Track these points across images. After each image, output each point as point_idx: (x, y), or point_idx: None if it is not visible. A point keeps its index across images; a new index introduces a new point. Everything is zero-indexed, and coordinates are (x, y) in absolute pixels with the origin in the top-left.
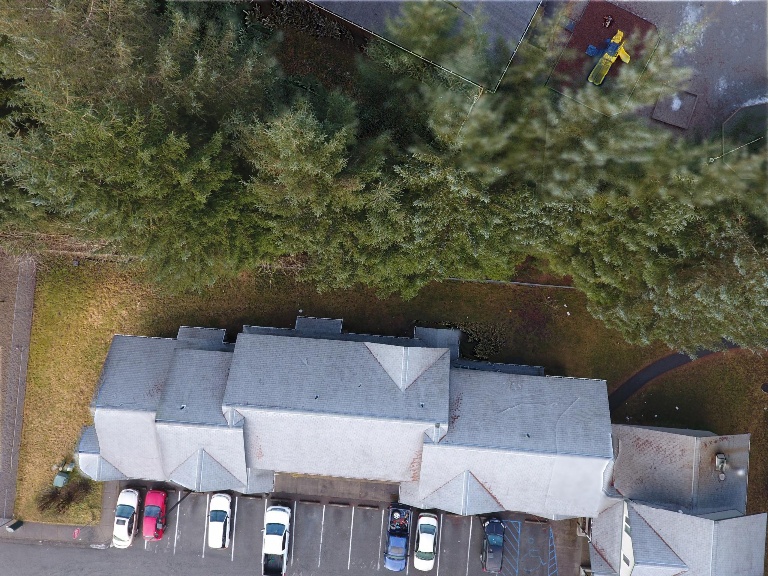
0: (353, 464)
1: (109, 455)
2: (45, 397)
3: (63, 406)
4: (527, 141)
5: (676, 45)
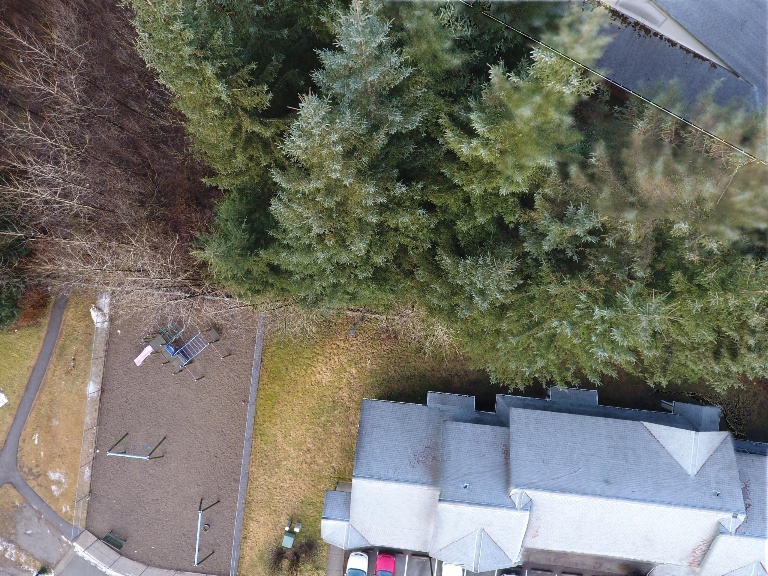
0: (631, 547)
1: (358, 523)
2: (271, 454)
3: (289, 464)
4: None
5: None
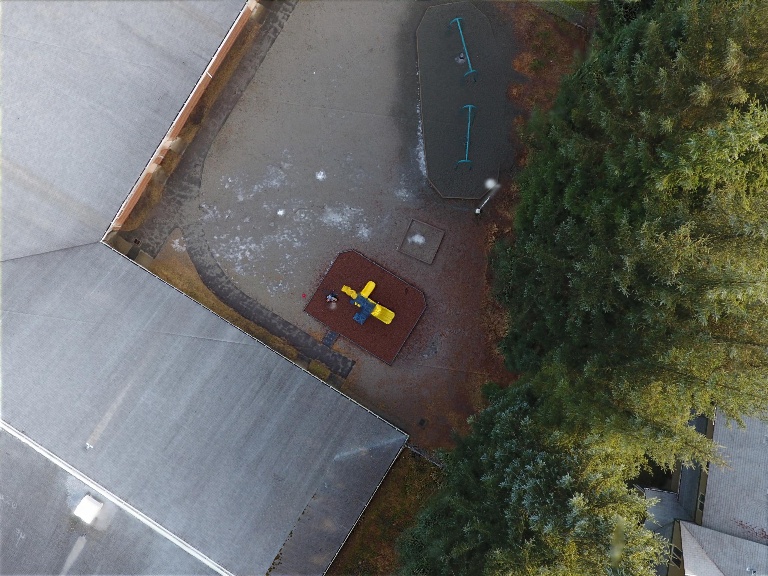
0: None
1: None
2: None
3: None
4: (443, 387)
5: (360, 234)
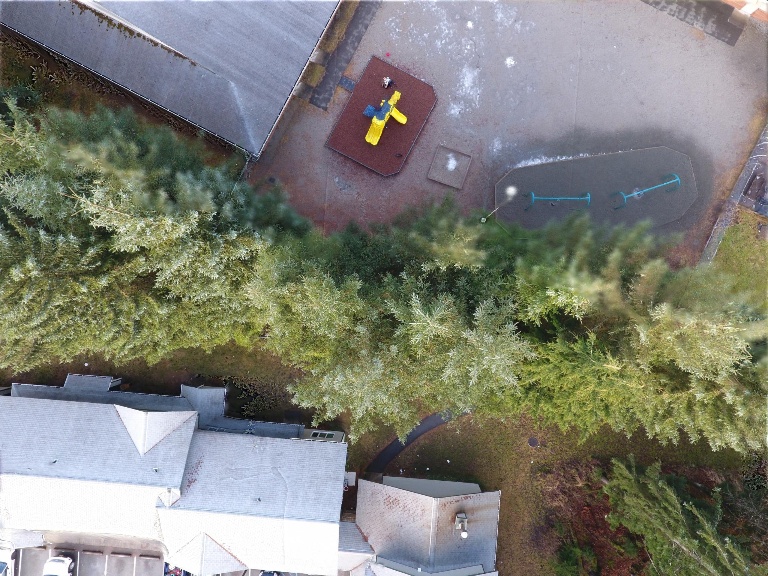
0: (99, 524)
1: None
2: None
3: None
4: (307, 199)
5: (453, 106)
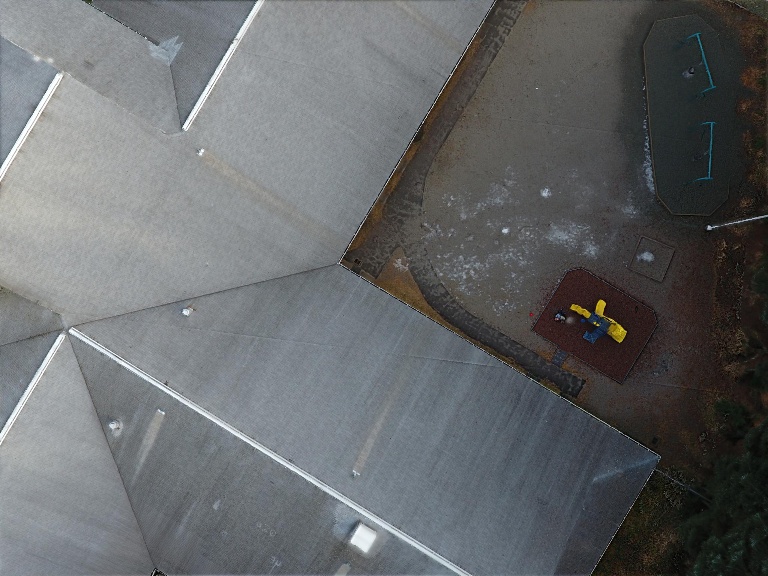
0: None
1: None
2: None
3: None
4: (675, 405)
5: (587, 252)
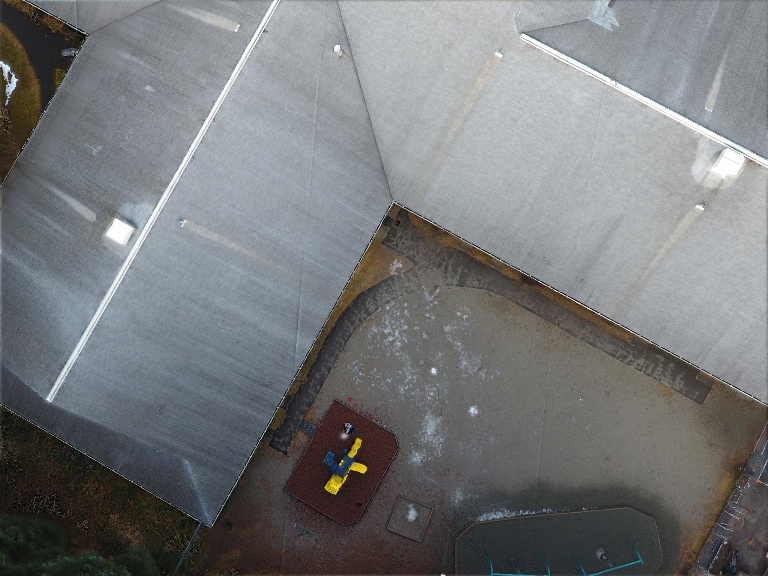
0: None
1: None
2: None
3: None
4: (264, 544)
5: (415, 454)
